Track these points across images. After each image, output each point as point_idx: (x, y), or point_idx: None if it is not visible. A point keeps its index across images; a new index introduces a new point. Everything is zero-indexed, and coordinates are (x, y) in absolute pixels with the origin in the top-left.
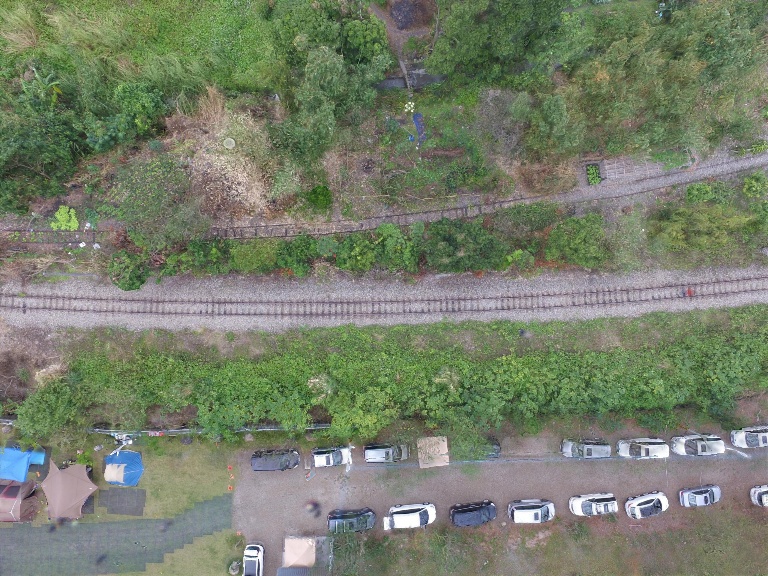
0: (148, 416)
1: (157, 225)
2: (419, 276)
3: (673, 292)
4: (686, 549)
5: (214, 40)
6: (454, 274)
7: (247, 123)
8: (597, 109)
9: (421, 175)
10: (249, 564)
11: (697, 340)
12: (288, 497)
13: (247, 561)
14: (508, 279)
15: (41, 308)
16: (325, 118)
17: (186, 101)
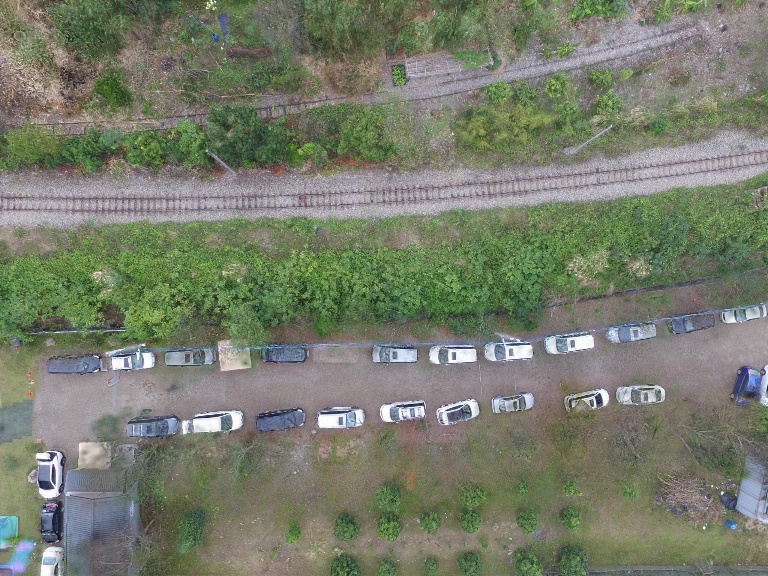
0: None
1: None
2: (216, 173)
3: (472, 190)
4: (501, 459)
5: None
6: (252, 172)
7: (44, 19)
8: None
9: (225, 75)
10: (43, 469)
11: (491, 236)
12: (91, 404)
13: (41, 466)
14: (307, 177)
15: None
16: None
17: None
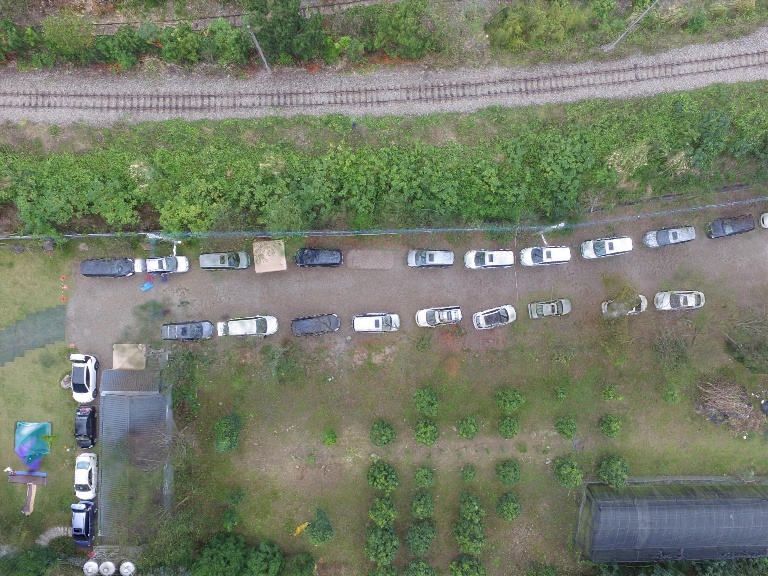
0: None
1: None
2: (251, 71)
3: (509, 87)
4: (538, 366)
5: None
6: (287, 70)
7: None
8: None
9: None
10: (77, 371)
11: None
12: (124, 309)
13: (75, 368)
14: (342, 75)
15: None
16: None
17: None
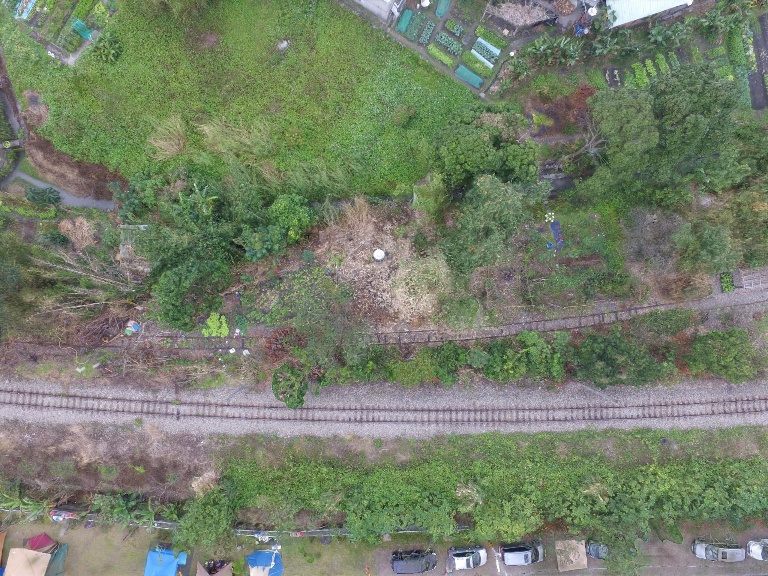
0: None
1: (304, 331)
2: (561, 384)
3: None
4: None
5: (354, 147)
6: None
7: (392, 232)
8: (747, 232)
9: (559, 282)
10: None
11: None
12: None
13: None
14: (648, 387)
15: (195, 415)
16: (494, 246)
17: (333, 210)
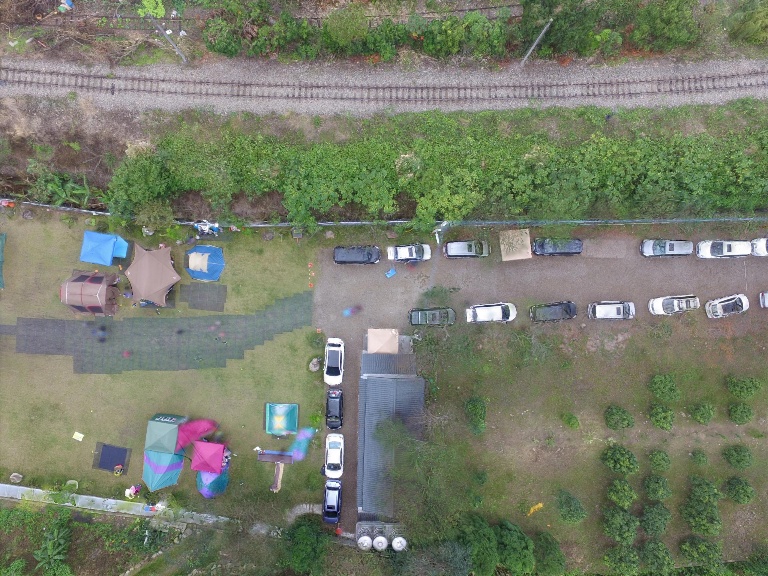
0: (232, 206)
1: None
2: (504, 63)
3: (759, 80)
4: (765, 354)
5: None
6: (539, 62)
7: None
8: None
9: None
10: (332, 354)
11: None
12: (368, 295)
13: (330, 351)
14: (593, 67)
15: (129, 89)
16: None
17: None
